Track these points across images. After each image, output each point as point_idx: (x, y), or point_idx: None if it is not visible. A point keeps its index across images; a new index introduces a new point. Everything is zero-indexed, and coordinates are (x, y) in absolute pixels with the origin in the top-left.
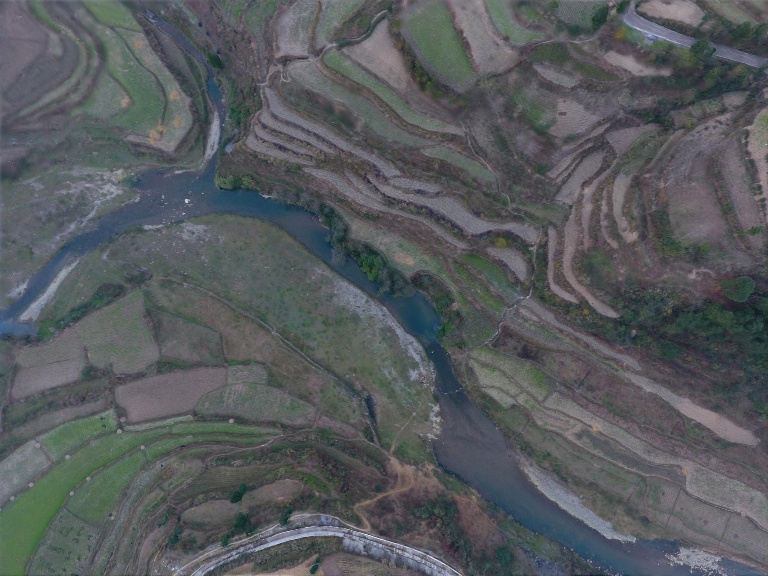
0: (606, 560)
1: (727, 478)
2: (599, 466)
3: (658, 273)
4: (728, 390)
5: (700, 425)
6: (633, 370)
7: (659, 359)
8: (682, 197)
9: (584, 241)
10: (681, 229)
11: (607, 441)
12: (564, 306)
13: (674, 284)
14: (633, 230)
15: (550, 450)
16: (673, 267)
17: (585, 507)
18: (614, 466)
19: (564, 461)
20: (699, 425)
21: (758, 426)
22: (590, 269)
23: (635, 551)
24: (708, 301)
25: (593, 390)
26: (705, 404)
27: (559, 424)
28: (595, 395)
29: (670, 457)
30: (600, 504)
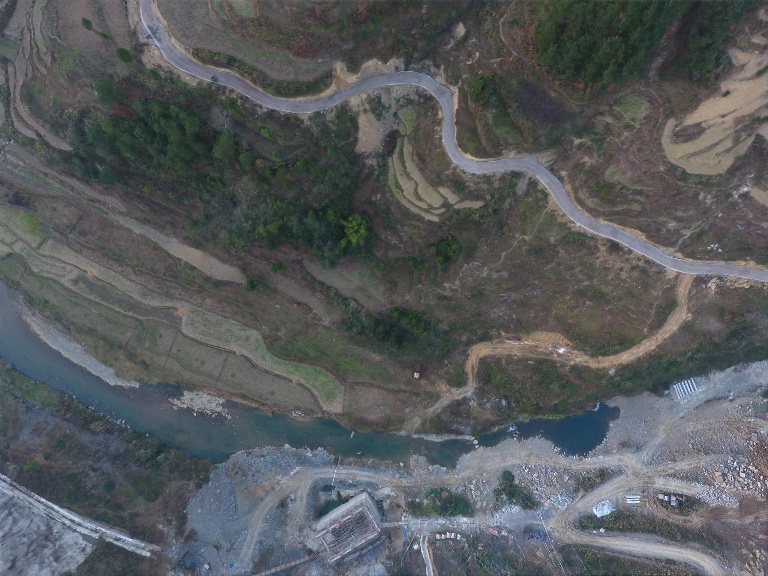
0: (110, 406)
1: (223, 318)
2: (96, 311)
3: (73, 93)
4: (199, 224)
5: (188, 264)
6: (118, 211)
7: (136, 197)
8: (69, 9)
9: (28, 72)
10: (68, 41)
11: (104, 286)
12: (30, 144)
13: (86, 103)
14: (48, 51)
15: (48, 297)
16: (79, 84)
17: (87, 354)
18: (112, 311)
19: (62, 308)
20: (187, 264)
21: (241, 262)
22: (29, 98)
23: (138, 396)
24: (112, 116)
25: (85, 234)
26: (186, 241)
27: (55, 271)
28: (87, 239)
29: (166, 299)
30: (102, 350)
